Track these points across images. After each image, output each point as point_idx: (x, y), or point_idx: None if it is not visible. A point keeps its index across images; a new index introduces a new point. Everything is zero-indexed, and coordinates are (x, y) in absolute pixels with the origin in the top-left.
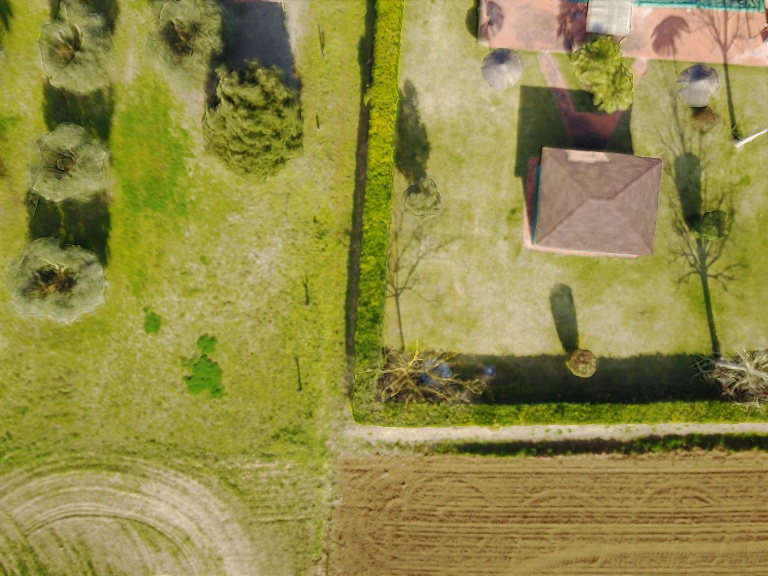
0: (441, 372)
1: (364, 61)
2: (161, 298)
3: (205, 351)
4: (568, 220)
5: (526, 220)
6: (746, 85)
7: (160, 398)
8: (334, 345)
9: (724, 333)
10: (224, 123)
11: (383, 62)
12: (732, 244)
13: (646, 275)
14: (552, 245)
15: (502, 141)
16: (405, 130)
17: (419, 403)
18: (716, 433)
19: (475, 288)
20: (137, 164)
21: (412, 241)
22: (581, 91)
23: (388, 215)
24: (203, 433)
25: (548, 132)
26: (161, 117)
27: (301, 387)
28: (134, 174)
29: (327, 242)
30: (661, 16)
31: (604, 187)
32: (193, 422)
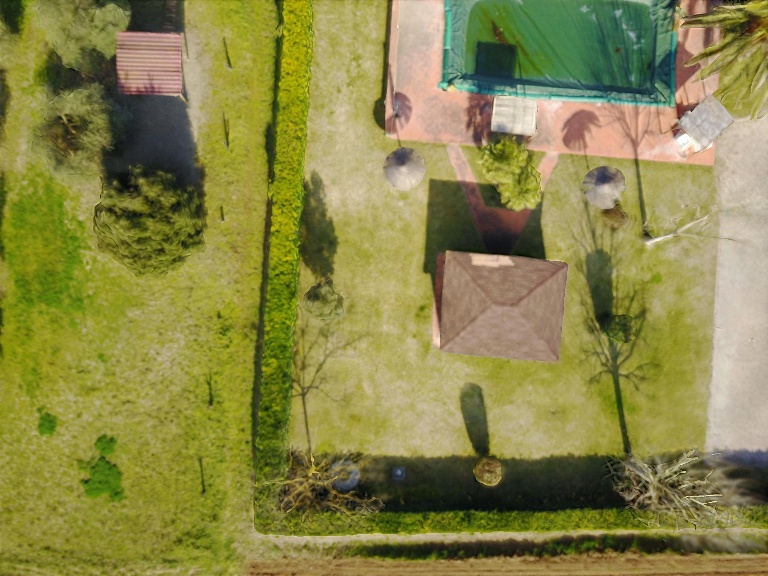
0: (349, 473)
1: (271, 149)
2: (56, 398)
3: (103, 453)
4: (472, 326)
5: (436, 317)
6: (657, 180)
7: (55, 503)
8: (240, 444)
9: (635, 433)
10: (110, 230)
11: (286, 157)
12: (643, 342)
13: (557, 374)
14: (456, 351)
15: (411, 236)
16: (312, 223)
17: None
18: (629, 533)
19: (383, 387)
20: (31, 258)
21: (319, 338)
22: (491, 185)
23: (291, 315)
24: (101, 539)
25: (458, 227)
26: (57, 209)
27: (204, 489)
28: (28, 268)
29: (232, 338)
30: (572, 109)
31: (508, 292)
32: (90, 528)
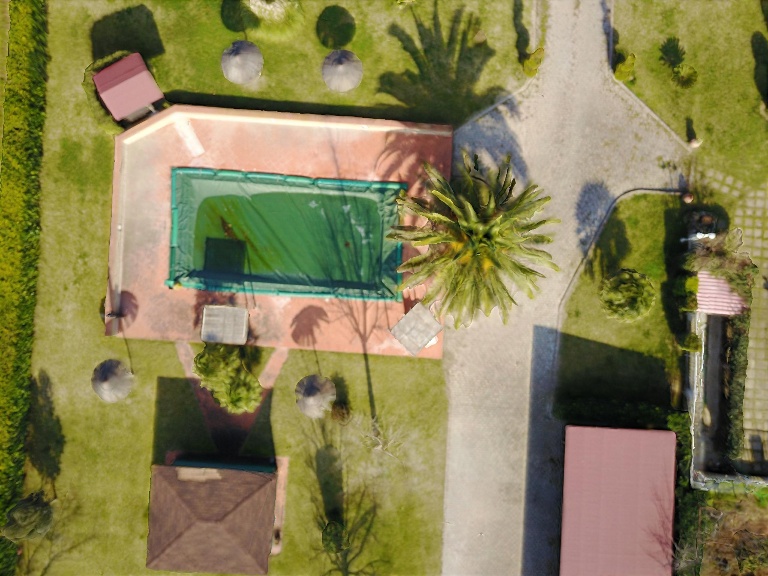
0: None
1: None
2: None
3: None
4: (177, 543)
5: None
6: (387, 374)
7: None
8: None
9: None
10: None
11: None
12: (373, 539)
13: (287, 573)
14: (161, 568)
15: (138, 435)
16: (39, 422)
17: None
18: None
19: None
20: None
21: (43, 542)
22: None
23: None
24: None
25: (186, 424)
26: None
27: None
28: None
29: None
30: (300, 305)
31: (213, 508)
32: None
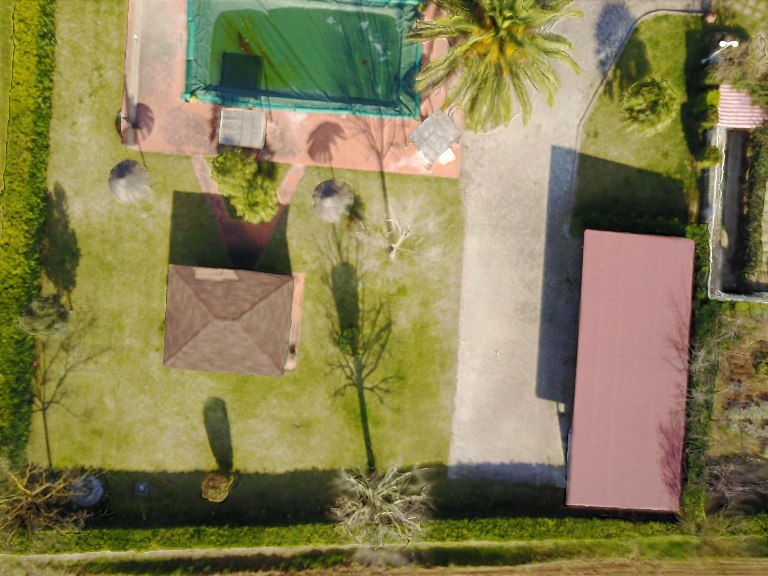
0: (90, 490)
1: None
2: None
3: None
4: (194, 341)
5: None
6: (404, 193)
7: None
8: None
9: (379, 447)
10: None
11: (16, 168)
12: (388, 355)
13: (302, 387)
14: (178, 366)
15: (154, 248)
16: (55, 235)
17: (47, 530)
18: None
19: (125, 402)
20: None
21: (59, 353)
22: None
23: None
24: None
25: (202, 239)
26: None
27: None
28: None
29: None
30: (317, 121)
31: (231, 306)
32: None
